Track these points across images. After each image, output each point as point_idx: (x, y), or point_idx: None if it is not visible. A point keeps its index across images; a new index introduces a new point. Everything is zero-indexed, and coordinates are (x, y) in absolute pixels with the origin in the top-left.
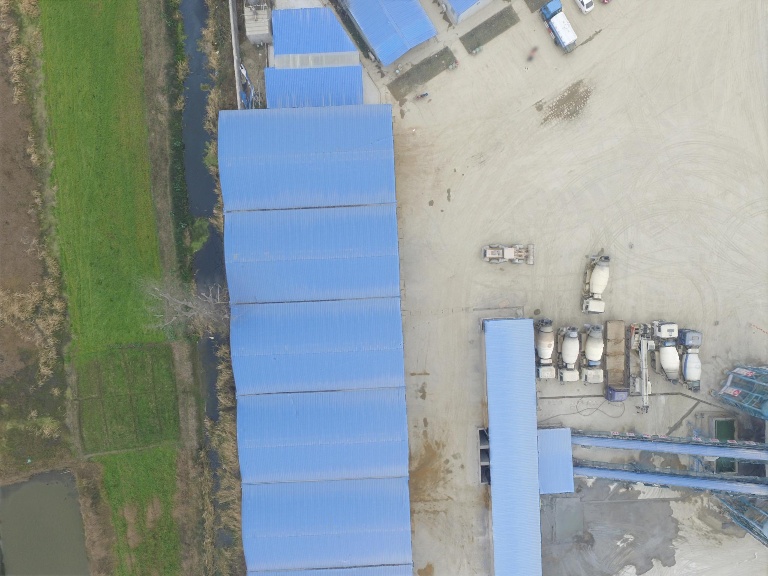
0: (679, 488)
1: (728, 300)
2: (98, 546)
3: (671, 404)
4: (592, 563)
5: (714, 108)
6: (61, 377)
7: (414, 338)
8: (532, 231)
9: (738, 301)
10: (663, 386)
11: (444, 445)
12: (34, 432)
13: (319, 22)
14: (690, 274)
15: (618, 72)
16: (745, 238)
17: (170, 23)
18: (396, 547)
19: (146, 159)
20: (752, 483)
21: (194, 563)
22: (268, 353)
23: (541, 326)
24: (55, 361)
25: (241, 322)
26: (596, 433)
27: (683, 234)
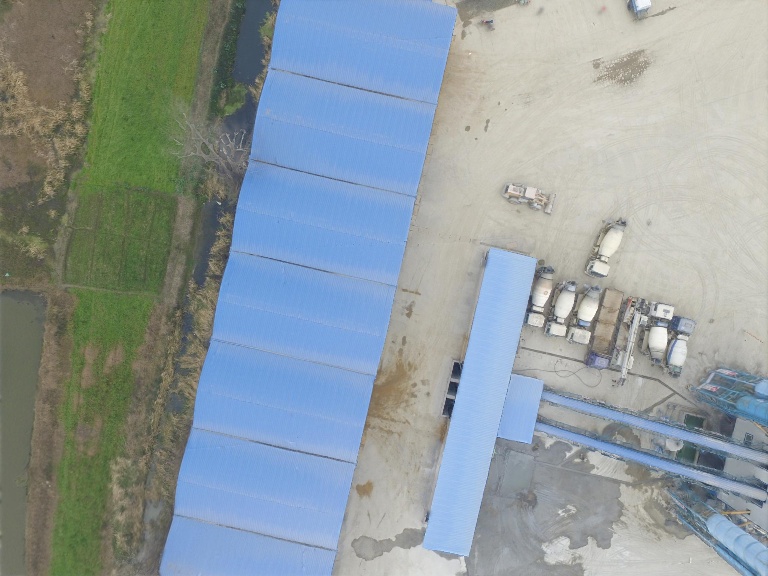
0: (633, 473)
1: (729, 301)
2: (51, 376)
3: (647, 388)
4: (529, 524)
5: (763, 112)
6: (62, 201)
7: (415, 255)
8: (557, 182)
9: (738, 305)
10: (644, 368)
11: (416, 368)
12: (20, 247)
13: None
14: (698, 266)
15: (681, 52)
16: (760, 246)
17: None
18: (345, 441)
19: (205, 12)
20: (708, 473)
21: (140, 419)
22: (273, 215)
23: (542, 272)
24: (61, 184)
25: (255, 178)
26: (567, 394)
27: (702, 225)
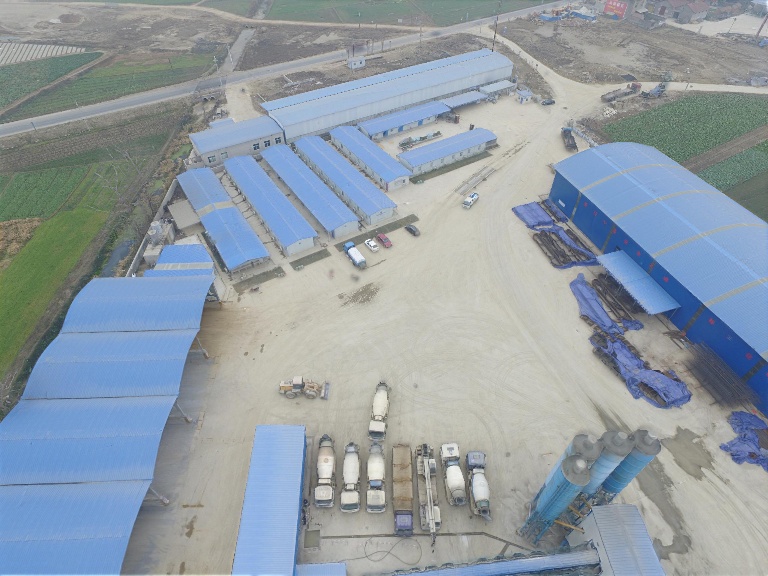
0: None
1: (514, 432)
2: None
3: (475, 547)
4: None
5: (470, 298)
6: None
7: (198, 466)
8: (328, 374)
9: (524, 433)
10: (463, 524)
11: None
12: None
13: (193, 250)
14: (473, 409)
15: (398, 279)
16: (516, 381)
17: (100, 257)
18: None
19: (33, 327)
20: None
21: None
22: (28, 438)
23: None
24: None
25: (20, 412)
26: None
27: (461, 377)
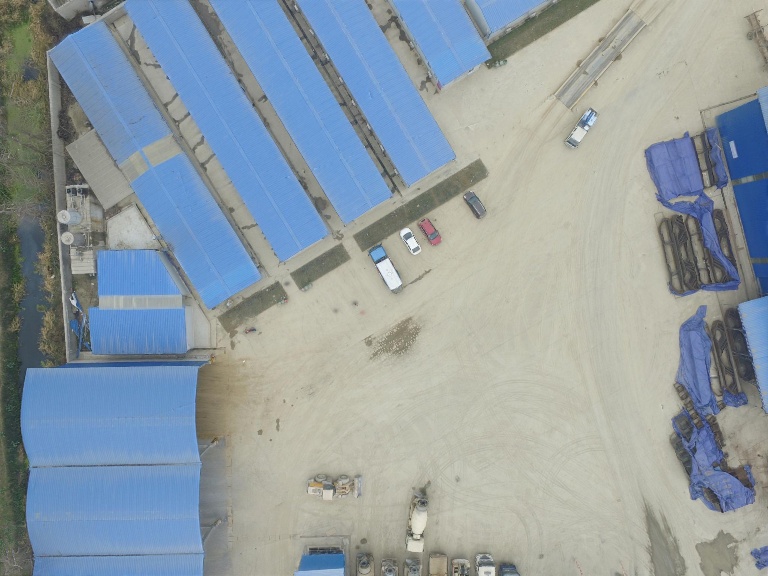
0: None
1: (553, 534)
2: None
3: None
4: None
5: (541, 348)
6: None
7: (241, 563)
8: (360, 462)
9: (563, 536)
10: None
11: None
12: None
13: (144, 264)
14: (516, 508)
15: (447, 311)
16: (570, 475)
17: (5, 249)
18: None
19: None
20: None
21: None
22: None
23: (359, 565)
24: None
25: None
26: None
27: (509, 469)
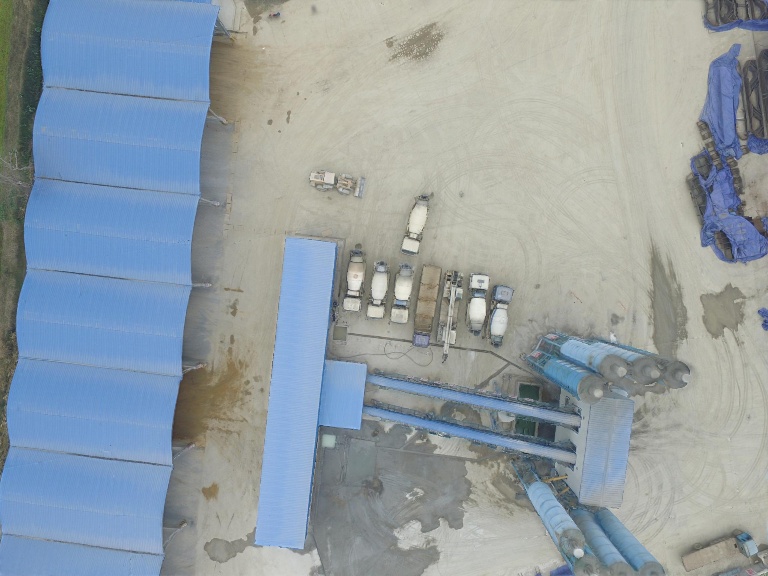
0: (477, 449)
1: (552, 265)
2: None
3: (480, 361)
4: (378, 511)
5: (564, 69)
6: None
7: (233, 253)
8: (365, 165)
9: (562, 267)
10: (475, 342)
11: (247, 365)
12: None
13: None
14: (517, 232)
15: (472, 20)
16: (578, 204)
17: None
18: (156, 445)
19: (7, 41)
20: (523, 440)
21: None
22: (60, 229)
23: (351, 256)
24: None
25: (41, 195)
26: (395, 376)
27: (516, 191)
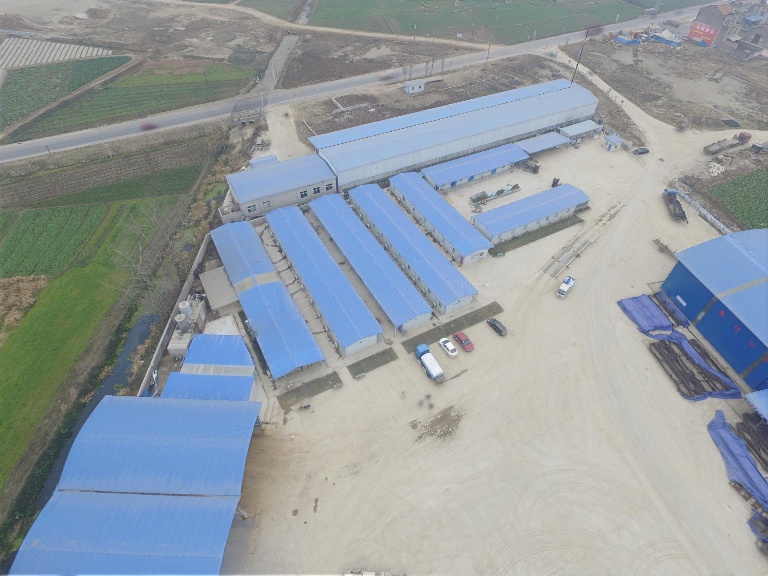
0: None
1: None
2: None
3: None
4: None
5: (581, 440)
6: None
7: None
8: (404, 557)
9: None
10: None
11: None
12: None
13: (230, 344)
14: None
15: (485, 402)
16: None
17: (115, 339)
18: None
19: (26, 443)
20: None
21: None
22: None
23: None
24: None
25: None
26: None
27: None
